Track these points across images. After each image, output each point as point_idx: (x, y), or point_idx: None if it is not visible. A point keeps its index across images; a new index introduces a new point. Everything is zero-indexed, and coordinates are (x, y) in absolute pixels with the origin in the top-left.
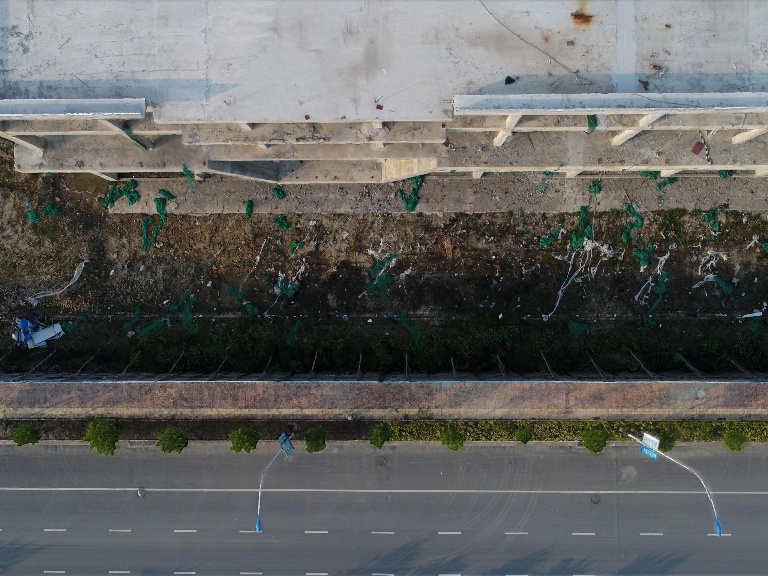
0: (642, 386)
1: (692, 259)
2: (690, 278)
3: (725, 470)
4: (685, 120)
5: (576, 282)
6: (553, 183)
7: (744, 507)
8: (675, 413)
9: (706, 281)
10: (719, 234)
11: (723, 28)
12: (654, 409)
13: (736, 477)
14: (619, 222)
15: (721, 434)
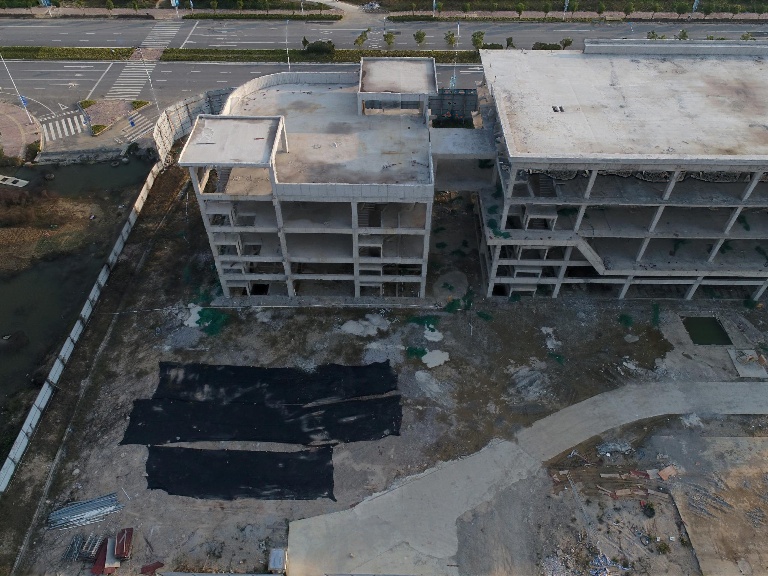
0: None
1: None
2: None
3: None
4: None
5: None
6: None
7: None
8: None
9: None
10: None
11: None
12: None
13: None
14: None
15: None
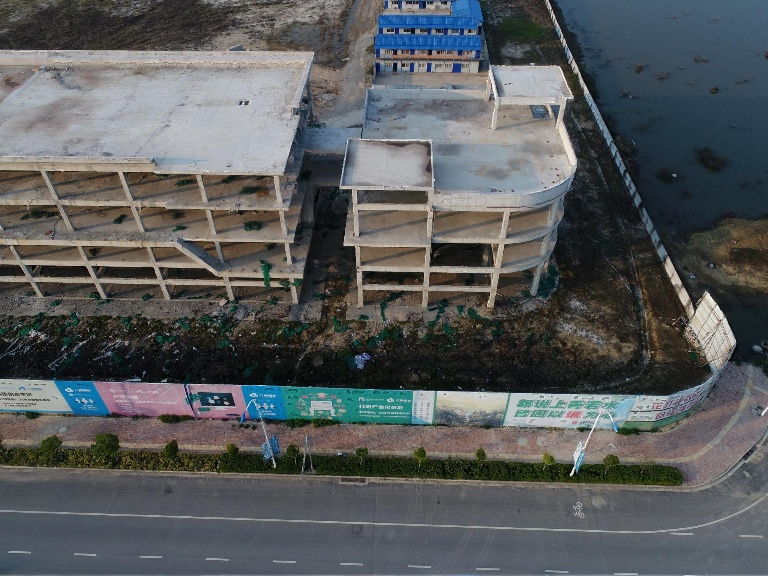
0: (18, 423)
1: (102, 344)
2: (94, 354)
3: (55, 493)
4: (8, 197)
5: (10, 355)
6: (29, 300)
7: (56, 526)
8: (34, 444)
9: (105, 356)
10: (129, 331)
11: (6, 144)
12: (18, 440)
13: (62, 499)
14: (62, 322)
15: (63, 460)
